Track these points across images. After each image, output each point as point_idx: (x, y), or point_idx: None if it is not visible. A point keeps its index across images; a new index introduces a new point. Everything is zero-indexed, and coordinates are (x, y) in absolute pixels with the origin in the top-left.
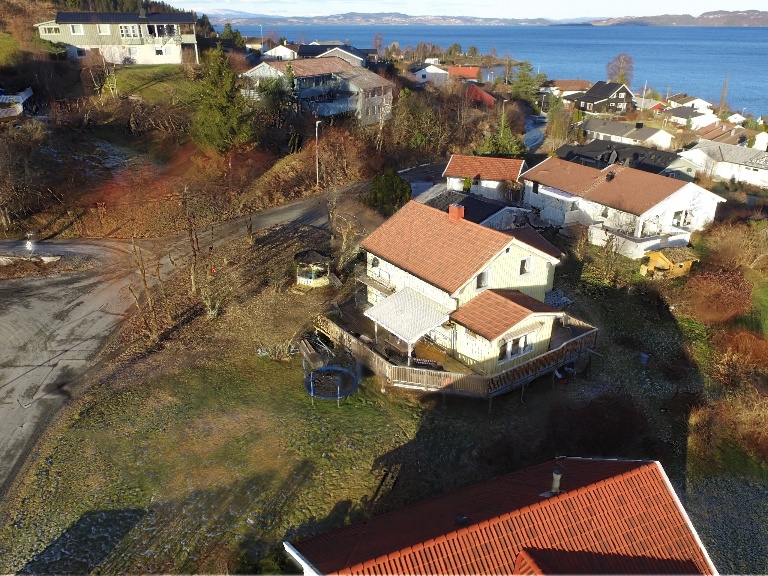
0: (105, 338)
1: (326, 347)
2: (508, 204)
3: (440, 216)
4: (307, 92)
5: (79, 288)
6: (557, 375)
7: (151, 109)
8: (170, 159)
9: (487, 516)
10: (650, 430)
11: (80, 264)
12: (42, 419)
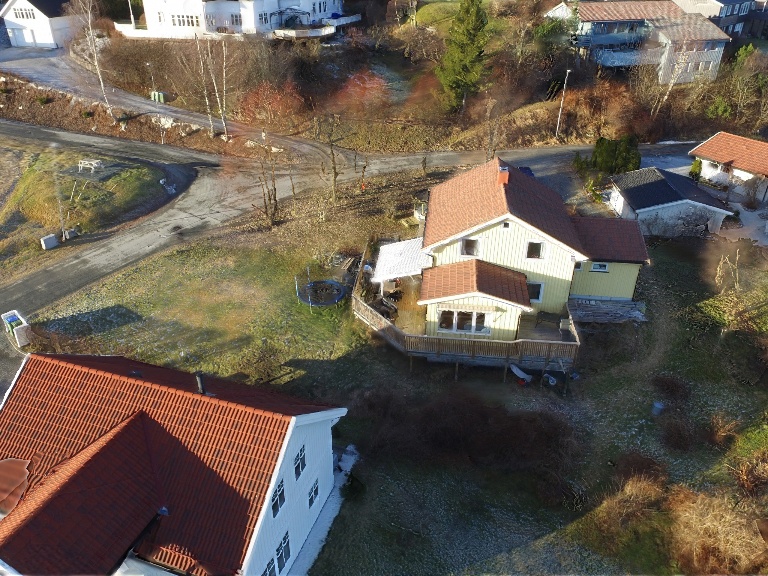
0: (247, 212)
1: None
2: (709, 199)
3: (495, 178)
4: (602, 38)
5: (274, 175)
6: (515, 372)
7: (429, 41)
8: (423, 88)
9: (150, 381)
10: (557, 467)
11: (293, 158)
12: (161, 247)
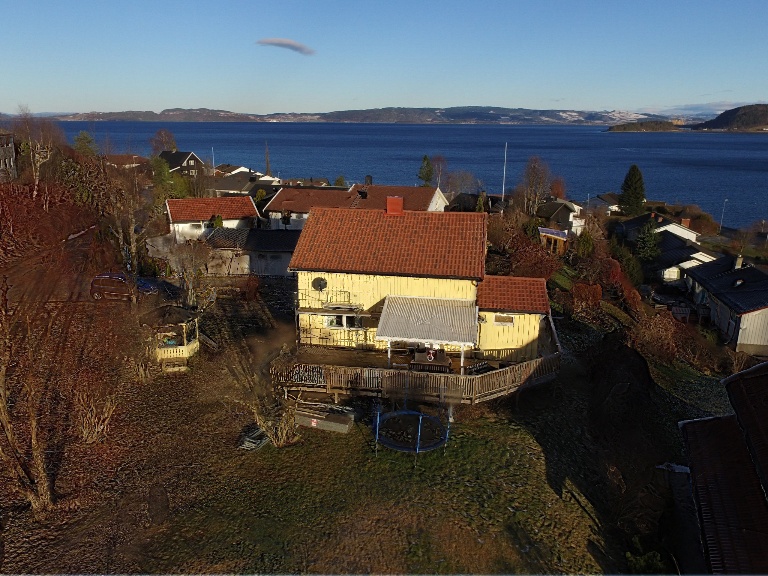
0: None
1: (327, 405)
2: None
3: (373, 214)
4: None
5: None
6: None
7: None
8: None
9: None
10: None
11: None
12: None
